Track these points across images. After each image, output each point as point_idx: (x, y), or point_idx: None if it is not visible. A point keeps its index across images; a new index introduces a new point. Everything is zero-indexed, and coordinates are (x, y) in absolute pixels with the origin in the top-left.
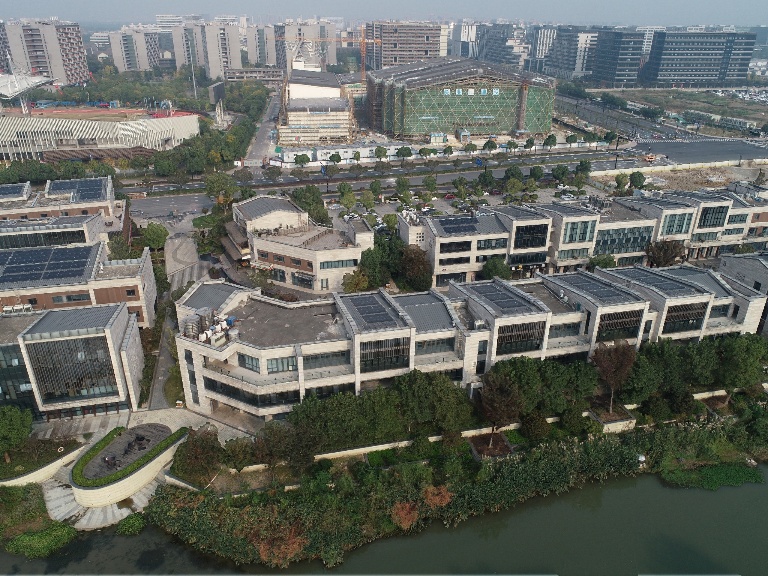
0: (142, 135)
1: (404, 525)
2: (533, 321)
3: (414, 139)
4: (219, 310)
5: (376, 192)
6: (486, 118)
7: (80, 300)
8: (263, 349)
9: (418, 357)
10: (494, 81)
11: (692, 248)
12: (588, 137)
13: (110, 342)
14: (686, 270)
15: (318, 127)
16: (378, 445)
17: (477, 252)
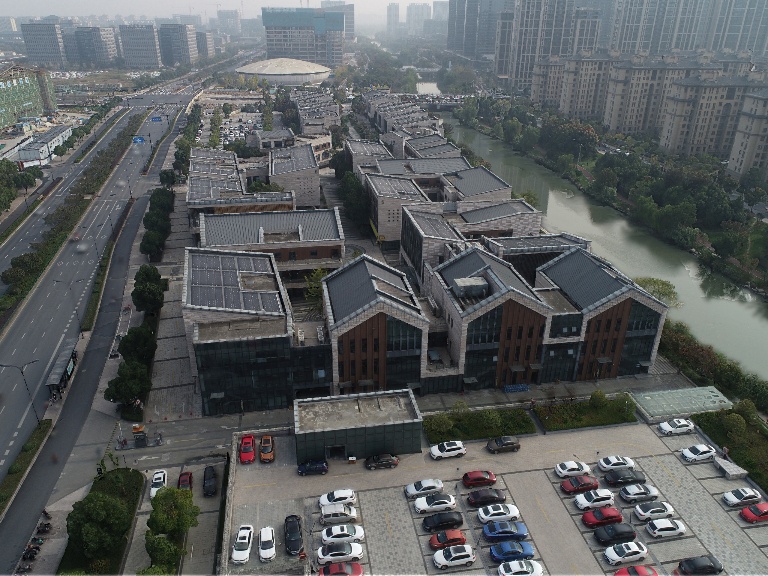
0: None
1: None
2: None
3: None
4: None
5: None
6: (28, 104)
7: None
8: None
9: None
10: (22, 71)
11: None
12: (113, 103)
13: None
14: None
15: None
16: None
17: None
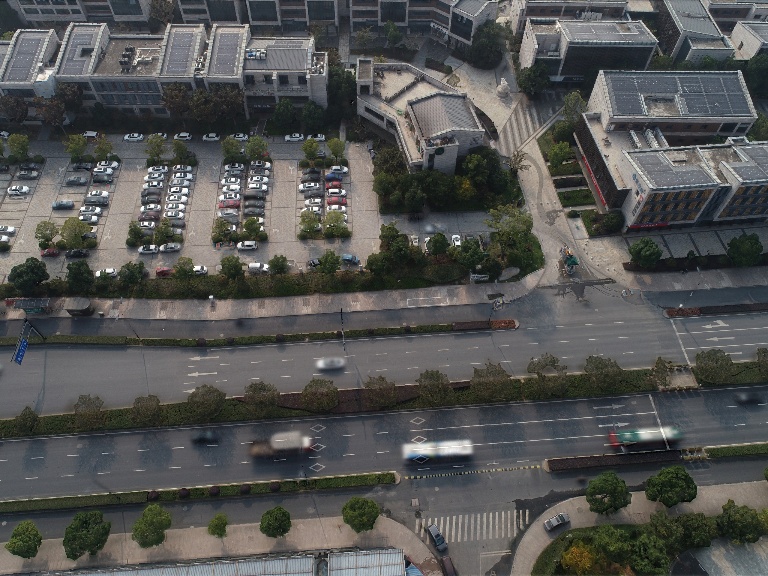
0: None
1: None
2: None
3: None
4: None
5: None
6: None
7: None
8: None
9: None
10: None
11: None
12: None
13: None
14: None
15: None
16: None
17: None
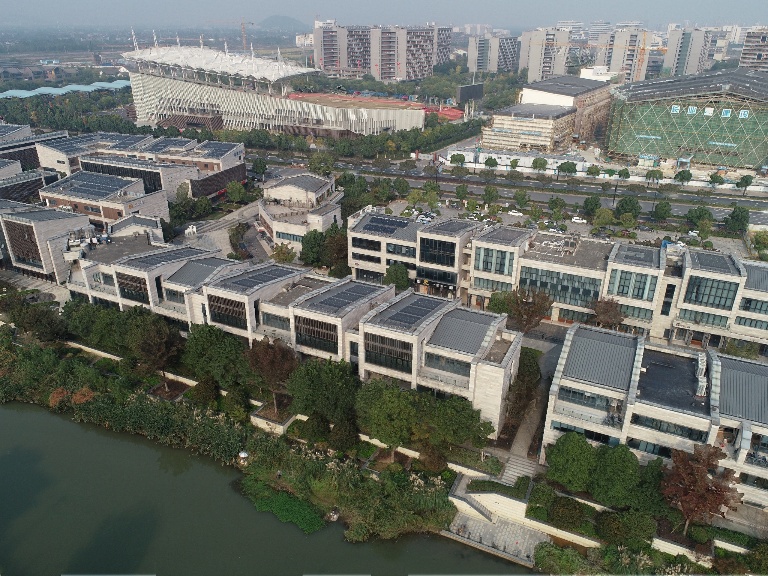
0: (361, 122)
1: (50, 402)
2: (235, 299)
3: (628, 159)
4: (113, 233)
5: (458, 196)
6: (725, 145)
7: (97, 212)
8: (80, 259)
9: (172, 303)
10: (744, 101)
11: (677, 327)
12: None
13: (35, 231)
14: (493, 319)
15: (519, 133)
16: (110, 354)
17: (387, 255)
